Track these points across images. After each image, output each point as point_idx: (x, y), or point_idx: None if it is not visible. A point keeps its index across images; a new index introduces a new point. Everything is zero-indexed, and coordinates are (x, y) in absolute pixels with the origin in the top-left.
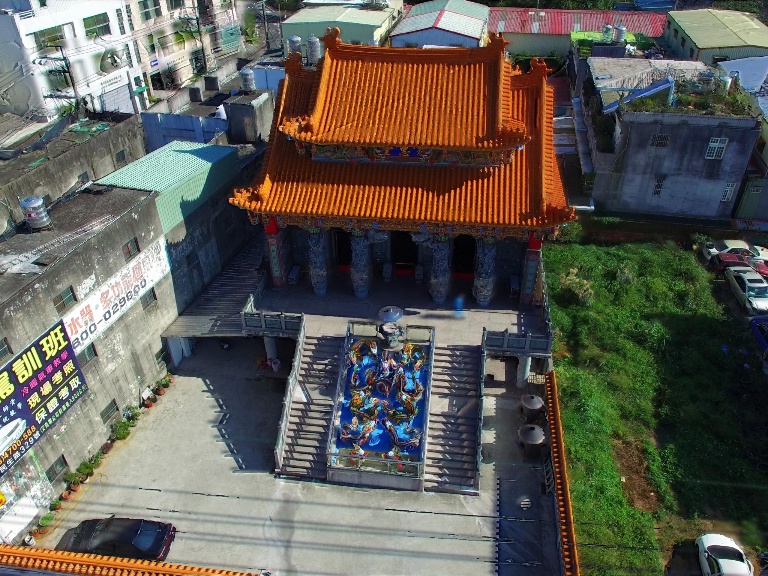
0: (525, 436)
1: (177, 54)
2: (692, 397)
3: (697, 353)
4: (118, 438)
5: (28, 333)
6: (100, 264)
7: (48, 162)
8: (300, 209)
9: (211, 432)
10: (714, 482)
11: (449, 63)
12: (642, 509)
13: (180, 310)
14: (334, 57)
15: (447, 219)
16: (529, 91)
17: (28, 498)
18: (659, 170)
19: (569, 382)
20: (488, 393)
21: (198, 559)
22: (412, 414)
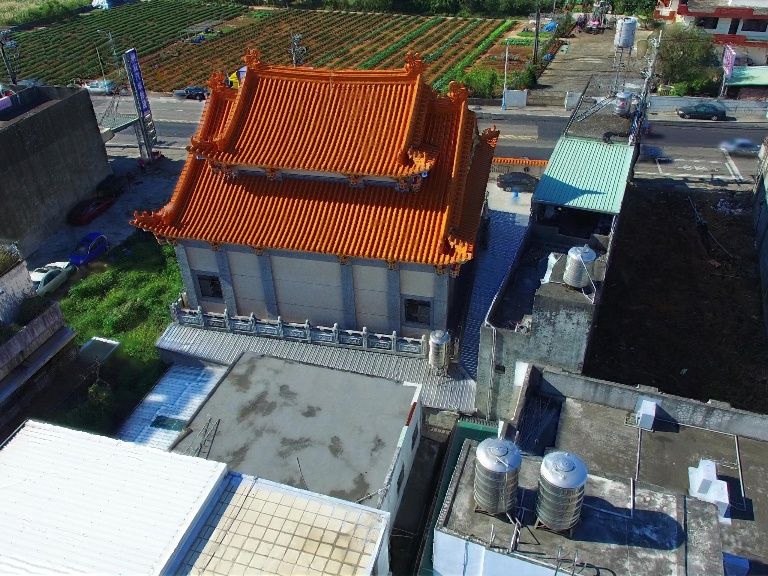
0: None
1: None
2: None
3: None
4: None
5: None
6: None
7: None
8: None
9: None
10: None
11: None
12: None
13: None
14: None
15: None
16: None
17: None
18: None
19: None
20: None
21: None
22: None
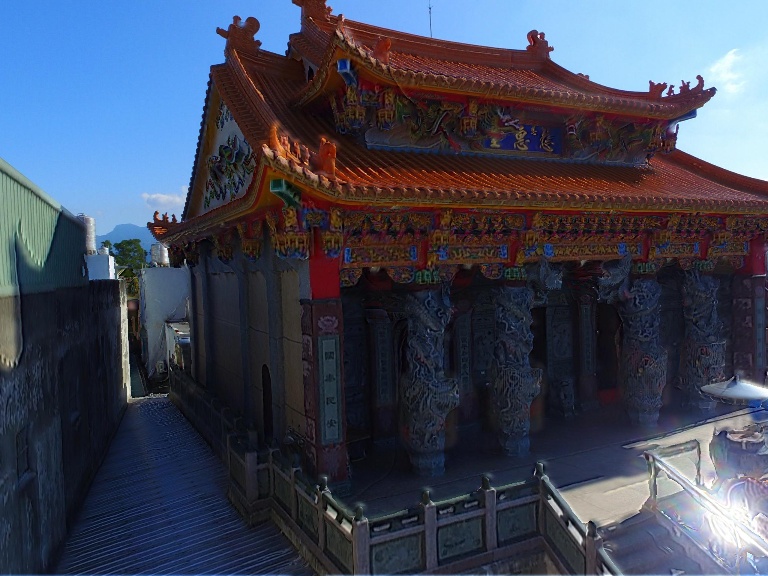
0: None
1: None
2: None
3: None
4: None
5: None
6: None
7: None
8: None
9: None
10: None
11: (489, 66)
12: None
13: None
14: None
15: (692, 199)
16: None
17: None
18: None
19: None
20: None
21: None
22: None
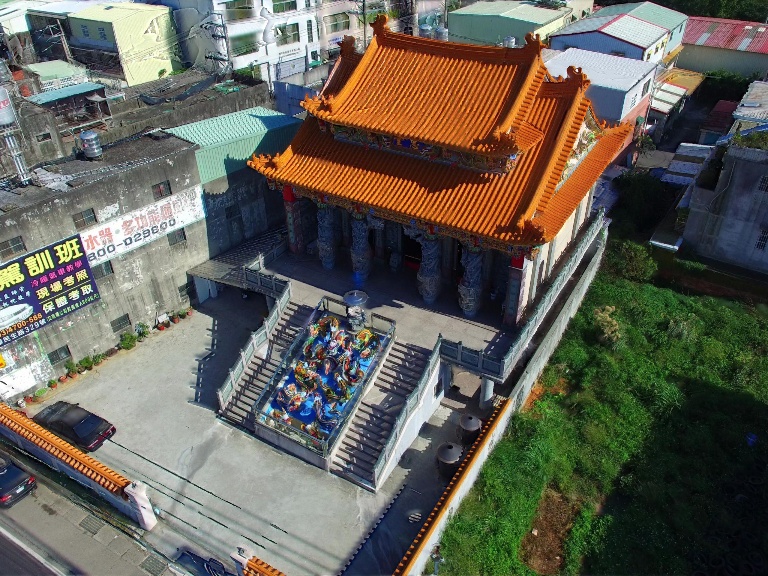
0: (441, 452)
1: (340, 33)
2: (669, 476)
3: (707, 432)
4: (123, 347)
5: (44, 237)
6: (126, 196)
7: (173, 111)
8: (303, 182)
9: (192, 364)
10: (637, 572)
11: (485, 61)
12: (535, 568)
13: (213, 255)
14: (381, 43)
15: (425, 217)
16: (562, 101)
17: (28, 370)
18: (766, 220)
19: (534, 418)
20: (447, 404)
21: (121, 460)
22: (344, 397)
